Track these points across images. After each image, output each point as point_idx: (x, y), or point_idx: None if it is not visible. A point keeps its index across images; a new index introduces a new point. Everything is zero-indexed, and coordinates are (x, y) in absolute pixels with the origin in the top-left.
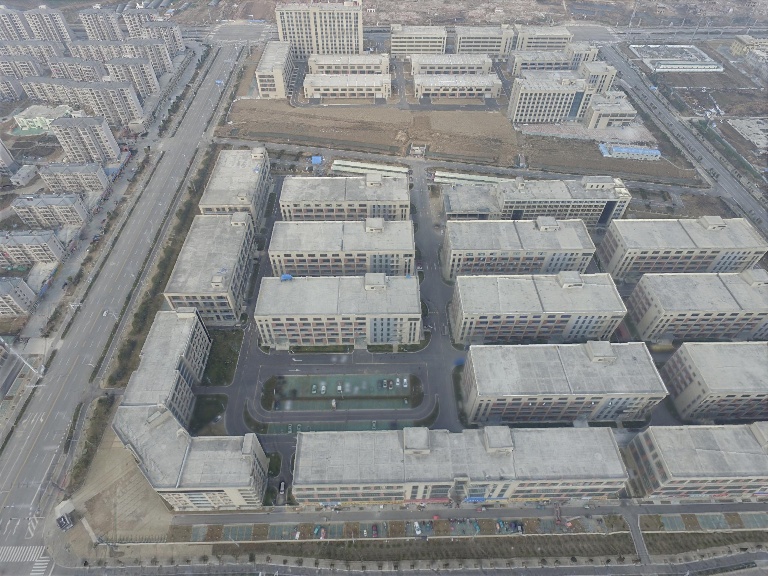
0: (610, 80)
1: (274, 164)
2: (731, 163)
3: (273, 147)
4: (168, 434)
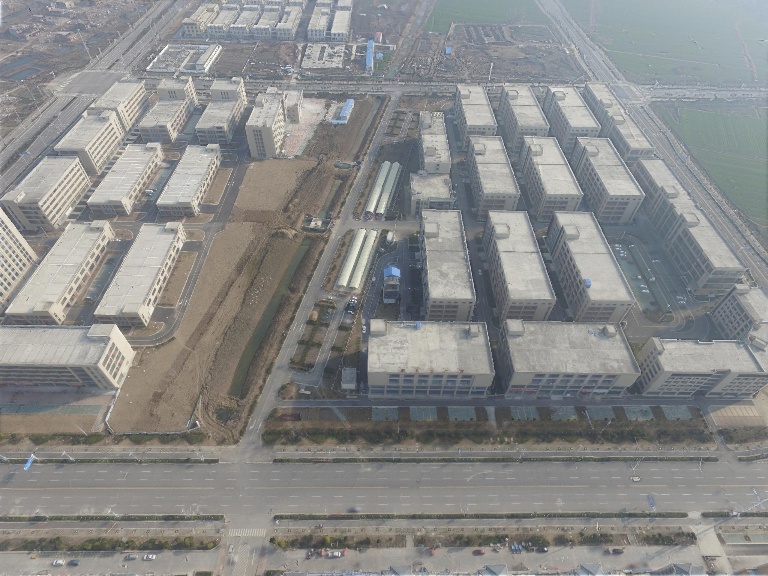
0: (243, 88)
1: (336, 348)
2: None
3: (289, 355)
4: (761, 336)
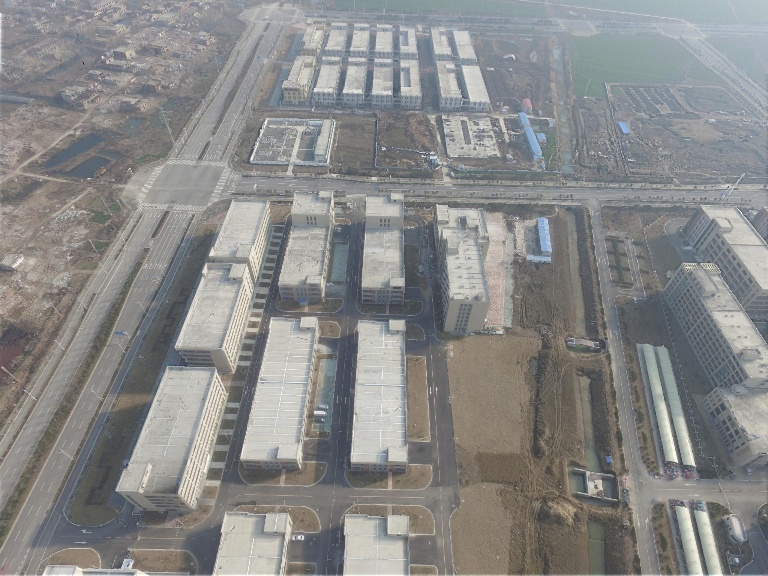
0: None
1: None
2: (536, 181)
3: None
4: None
